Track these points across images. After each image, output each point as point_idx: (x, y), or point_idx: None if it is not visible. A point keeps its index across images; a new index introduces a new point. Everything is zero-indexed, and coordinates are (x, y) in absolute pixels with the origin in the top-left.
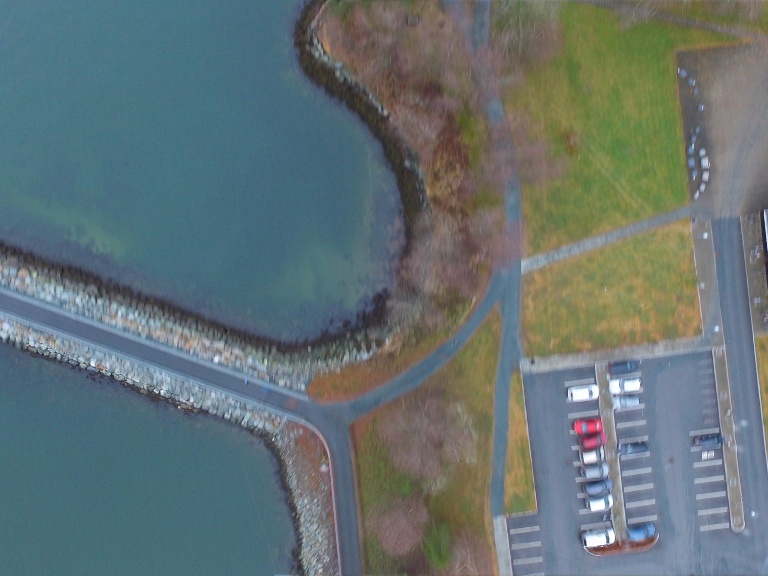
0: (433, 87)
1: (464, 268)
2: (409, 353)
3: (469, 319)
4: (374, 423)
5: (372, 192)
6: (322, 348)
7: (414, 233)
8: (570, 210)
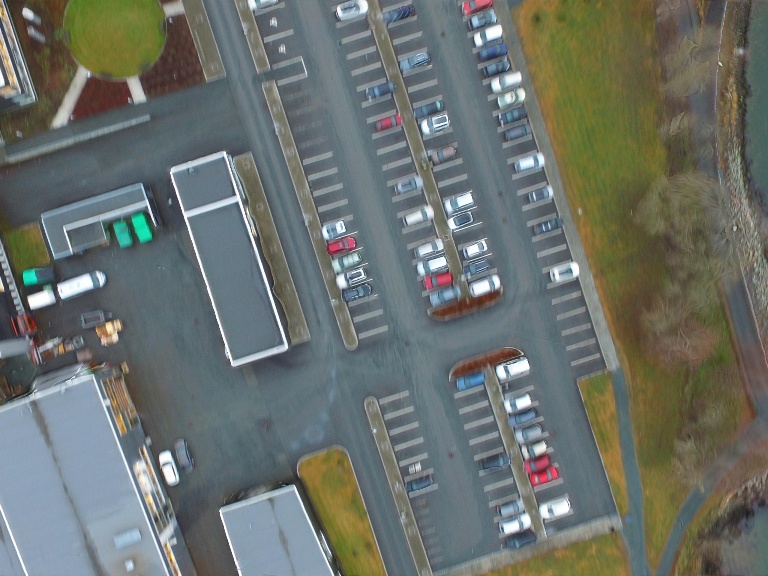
0: None
1: None
2: (717, 501)
3: (676, 553)
4: (736, 424)
5: None
6: None
7: None
8: None
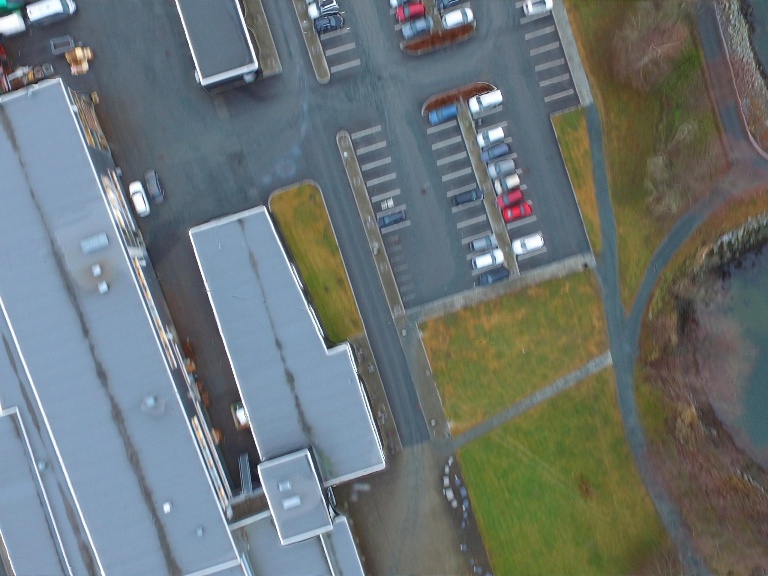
0: (722, 512)
1: (661, 344)
2: (692, 250)
3: (650, 295)
4: (711, 174)
5: (735, 397)
6: (762, 237)
7: (694, 366)
8: (573, 421)
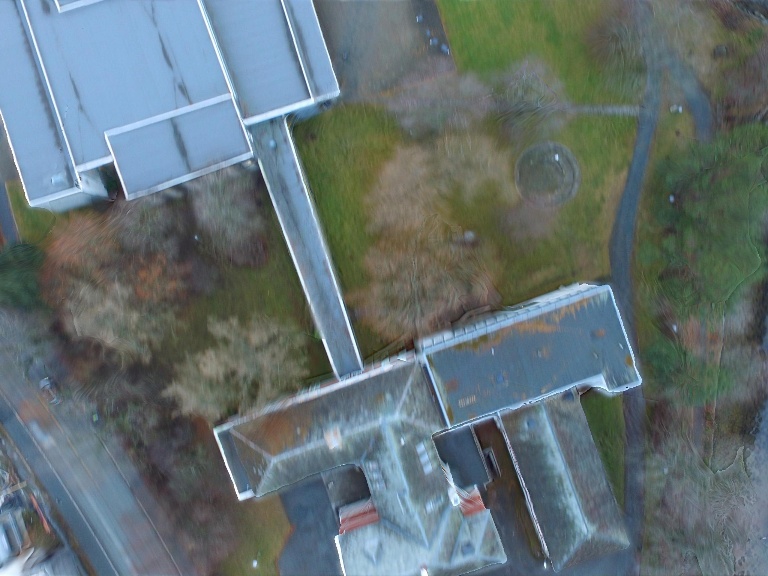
0: None
1: None
2: None
3: None
4: None
5: None
6: None
7: None
8: None
